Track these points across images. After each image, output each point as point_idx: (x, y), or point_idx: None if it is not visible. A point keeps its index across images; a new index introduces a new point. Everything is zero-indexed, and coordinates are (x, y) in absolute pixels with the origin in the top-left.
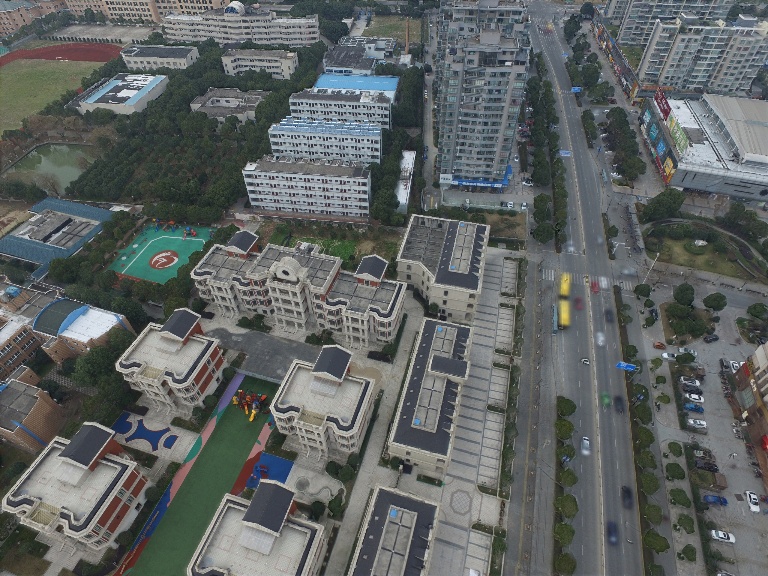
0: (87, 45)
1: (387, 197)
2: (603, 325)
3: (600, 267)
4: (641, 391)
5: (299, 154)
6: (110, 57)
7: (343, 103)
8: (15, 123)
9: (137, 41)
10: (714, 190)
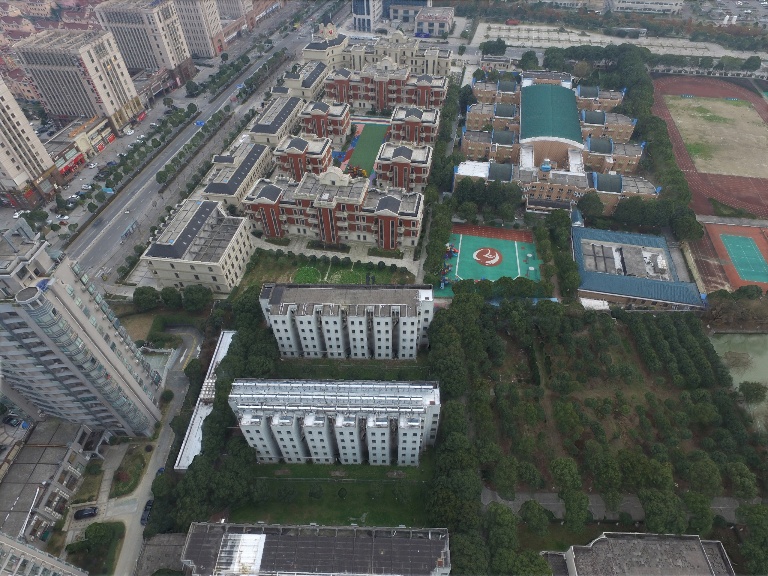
0: None
1: None
2: (93, 234)
3: None
4: None
5: None
6: None
7: (308, 527)
8: None
9: None
10: None
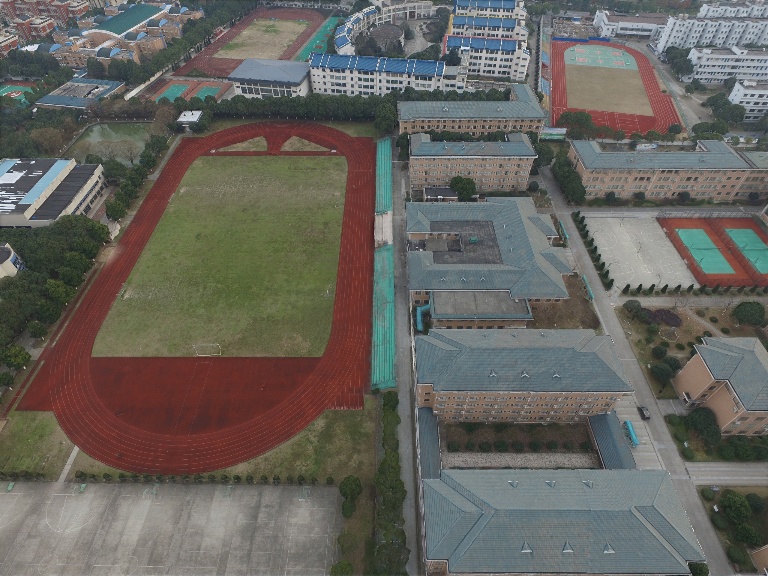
0: (184, 452)
1: None
2: None
3: None
4: None
5: None
6: (101, 381)
7: None
8: (193, 187)
9: (24, 472)
10: None
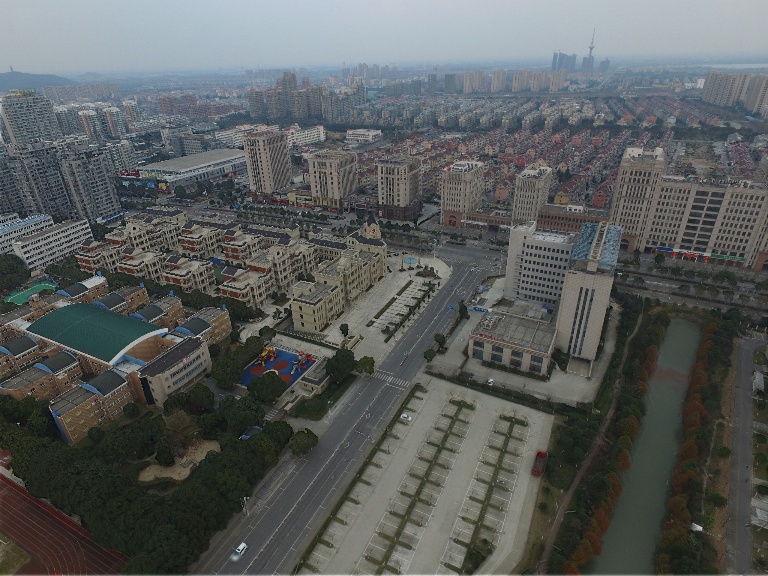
0: None
1: (100, 224)
2: None
3: (193, 209)
4: (246, 206)
5: (6, 249)
6: None
7: None
8: None
9: None
10: (184, 185)
